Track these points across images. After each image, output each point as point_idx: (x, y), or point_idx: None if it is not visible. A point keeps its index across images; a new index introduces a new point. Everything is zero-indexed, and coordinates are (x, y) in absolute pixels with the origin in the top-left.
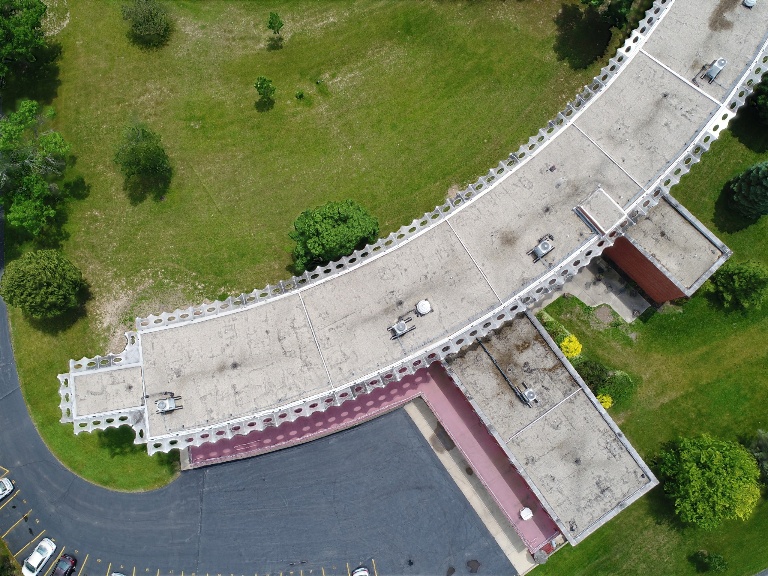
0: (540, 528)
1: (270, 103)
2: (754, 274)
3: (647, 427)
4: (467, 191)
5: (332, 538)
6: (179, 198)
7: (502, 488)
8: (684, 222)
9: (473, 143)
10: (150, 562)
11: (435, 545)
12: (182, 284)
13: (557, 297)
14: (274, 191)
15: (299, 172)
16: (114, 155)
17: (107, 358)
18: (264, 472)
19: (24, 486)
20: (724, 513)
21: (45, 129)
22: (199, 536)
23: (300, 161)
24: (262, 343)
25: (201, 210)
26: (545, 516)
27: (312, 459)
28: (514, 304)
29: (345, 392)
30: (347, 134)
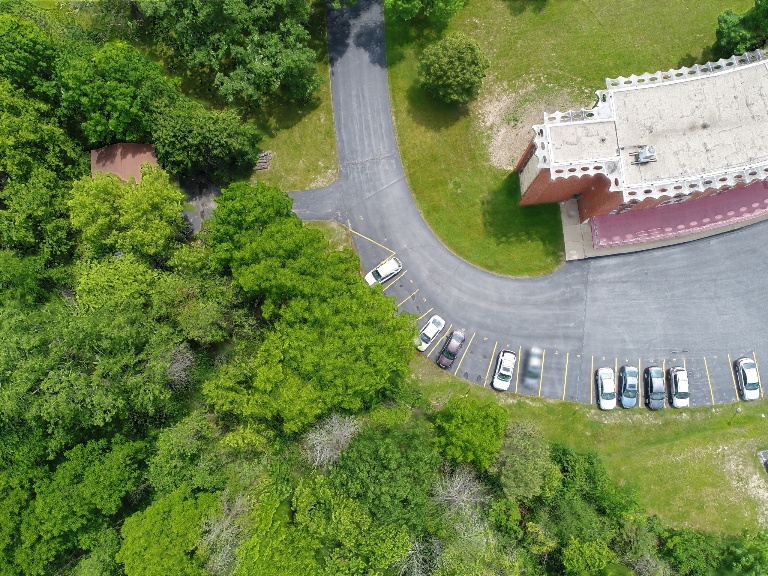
0: None
1: None
2: None
3: None
4: None
5: (713, 331)
6: (558, 11)
7: None
8: None
9: None
10: (536, 343)
11: None
12: (568, 88)
13: None
14: (655, 8)
15: None
16: None
17: (580, 113)
18: (647, 266)
19: (411, 267)
20: None
21: None
22: (584, 322)
23: None
24: (731, 107)
25: (582, 22)
26: None
27: (693, 257)
28: None
29: None
30: None
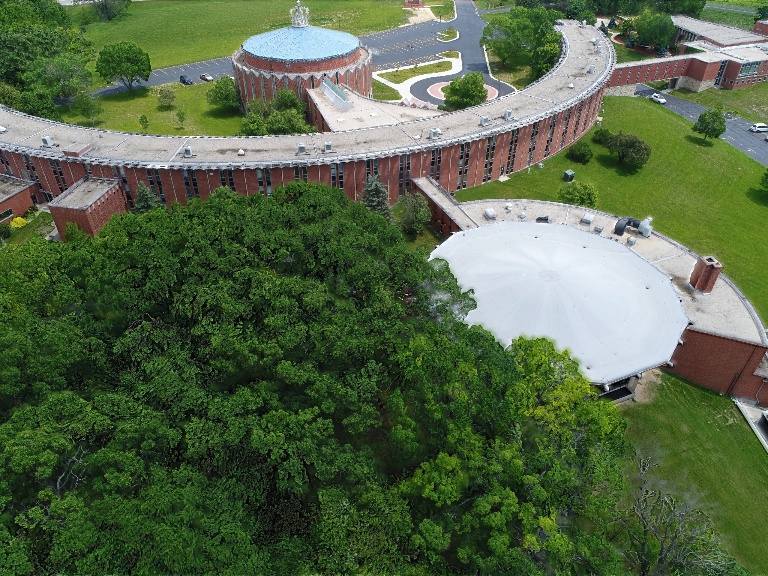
0: None
1: None
2: None
3: None
4: None
5: None
6: None
7: None
8: None
9: None
10: None
11: None
12: None
13: None
14: None
15: None
16: None
17: None
18: None
19: None
20: None
21: (102, 104)
22: None
23: None
24: None
25: None
26: None
27: None
28: (12, 148)
29: None
30: None
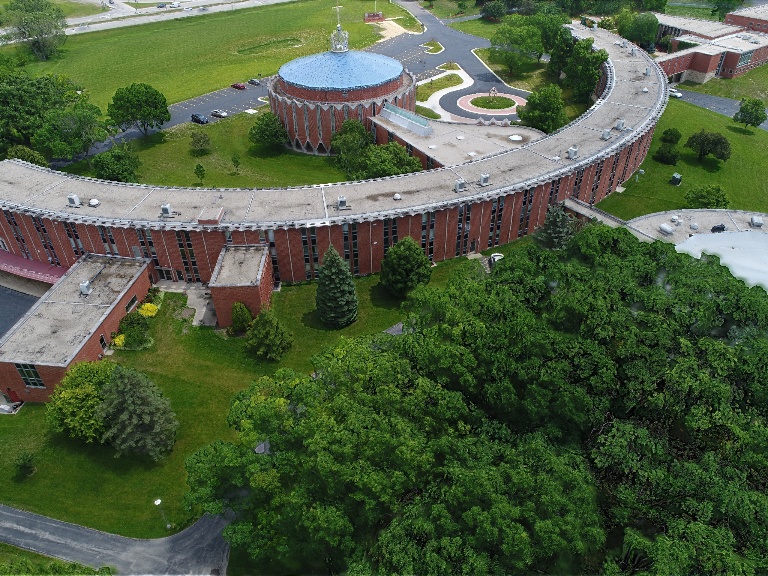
0: None
1: (200, 185)
2: None
3: None
4: None
5: None
6: None
7: None
8: (258, 264)
9: None
10: None
11: None
12: None
13: (180, 292)
14: None
15: None
16: None
17: None
18: None
19: None
20: None
21: None
22: None
23: None
24: None
25: None
26: None
27: None
28: None
29: (20, 209)
30: None
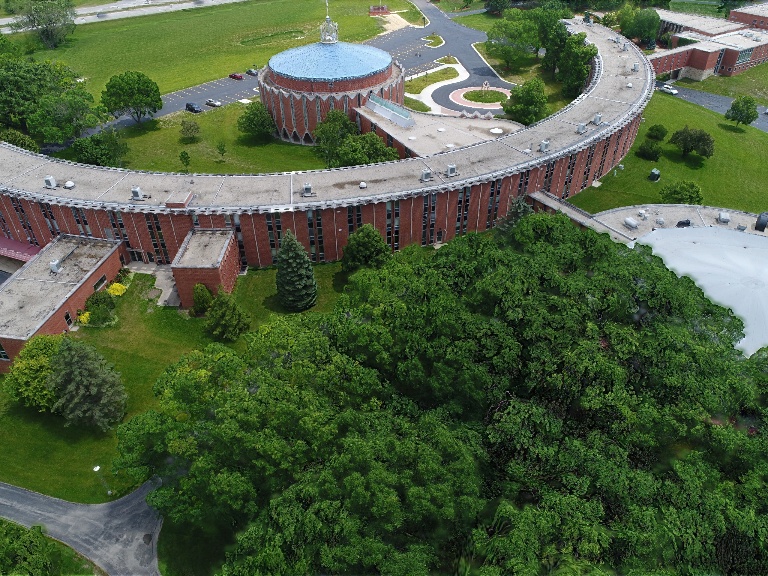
0: None
1: None
2: None
3: None
4: None
5: None
6: None
7: None
8: None
9: None
10: None
11: None
12: None
13: (149, 273)
14: None
15: None
16: None
17: None
18: None
19: None
20: None
21: None
22: None
23: None
24: None
25: None
26: None
27: None
28: (97, 205)
29: None
30: None
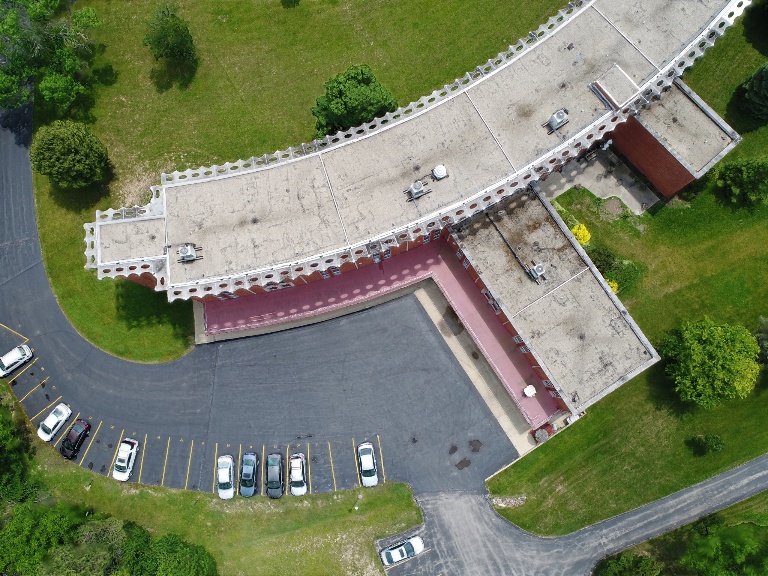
0: (542, 406)
1: None
2: (762, 164)
3: (651, 315)
4: (486, 66)
5: (339, 414)
6: (204, 87)
7: (507, 367)
8: (696, 109)
9: (492, 42)
10: (162, 430)
11: (439, 424)
12: None
13: (568, 188)
14: (296, 82)
15: (321, 65)
16: (142, 45)
17: (132, 210)
18: (276, 349)
19: (43, 354)
20: (723, 389)
21: None
22: (210, 407)
23: (323, 55)
24: (282, 201)
25: (225, 99)
26: (548, 395)
27: (323, 338)
28: (527, 173)
29: (360, 249)
30: (370, 31)
